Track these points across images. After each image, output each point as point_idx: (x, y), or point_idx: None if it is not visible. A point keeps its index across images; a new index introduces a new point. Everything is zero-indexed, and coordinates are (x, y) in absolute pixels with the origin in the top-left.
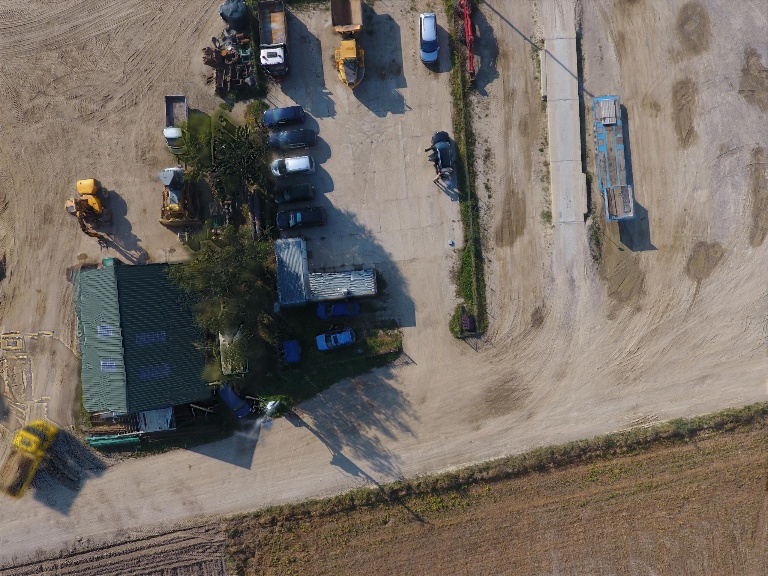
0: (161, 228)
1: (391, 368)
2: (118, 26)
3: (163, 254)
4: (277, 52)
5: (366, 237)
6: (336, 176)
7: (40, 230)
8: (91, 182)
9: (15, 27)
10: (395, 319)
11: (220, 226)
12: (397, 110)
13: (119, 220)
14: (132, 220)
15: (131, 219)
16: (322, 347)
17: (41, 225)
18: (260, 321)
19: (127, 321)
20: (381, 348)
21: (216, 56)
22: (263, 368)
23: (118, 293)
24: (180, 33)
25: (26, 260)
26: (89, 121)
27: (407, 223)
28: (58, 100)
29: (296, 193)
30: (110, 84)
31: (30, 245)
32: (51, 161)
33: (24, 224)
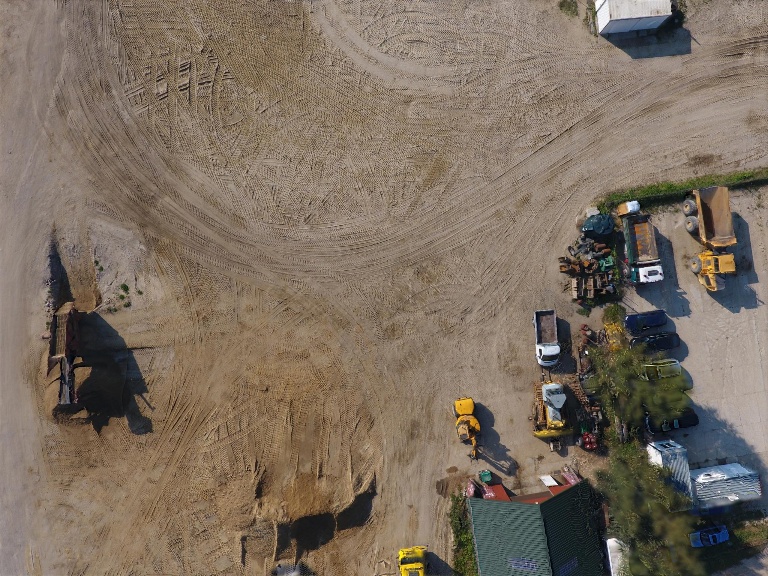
0: (529, 437)
1: (760, 558)
2: (473, 239)
3: (532, 462)
4: (658, 270)
5: (728, 431)
6: (695, 373)
7: (408, 446)
8: (471, 403)
9: (370, 246)
10: (760, 510)
11: (587, 431)
12: (750, 305)
13: (487, 431)
14: (500, 431)
15: (499, 430)
16: (697, 545)
17: (409, 441)
18: (629, 520)
19: (553, 557)
20: (749, 539)
21: (580, 268)
22: (635, 567)
23: (545, 531)
24: (534, 243)
25: (396, 476)
26: (449, 334)
27: (766, 415)
28: (418, 316)
29: (668, 398)
30: (468, 297)
31: (399, 461)
32: (414, 376)
33: (391, 441)
